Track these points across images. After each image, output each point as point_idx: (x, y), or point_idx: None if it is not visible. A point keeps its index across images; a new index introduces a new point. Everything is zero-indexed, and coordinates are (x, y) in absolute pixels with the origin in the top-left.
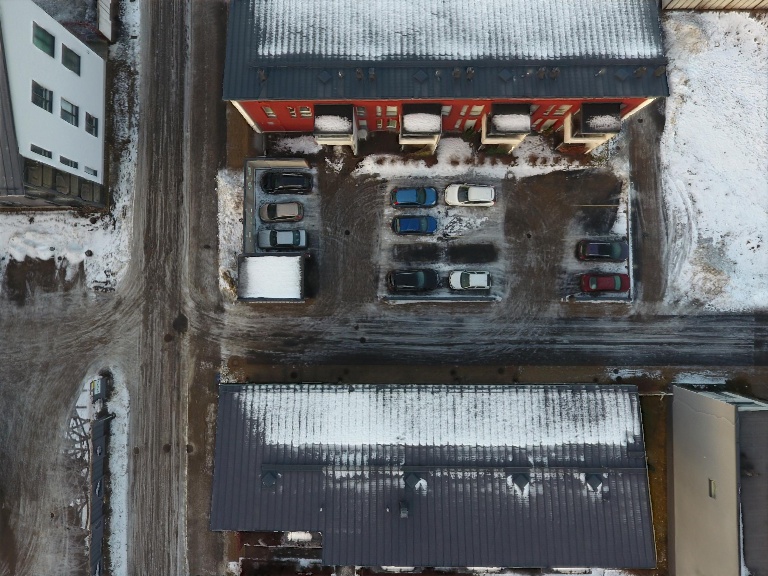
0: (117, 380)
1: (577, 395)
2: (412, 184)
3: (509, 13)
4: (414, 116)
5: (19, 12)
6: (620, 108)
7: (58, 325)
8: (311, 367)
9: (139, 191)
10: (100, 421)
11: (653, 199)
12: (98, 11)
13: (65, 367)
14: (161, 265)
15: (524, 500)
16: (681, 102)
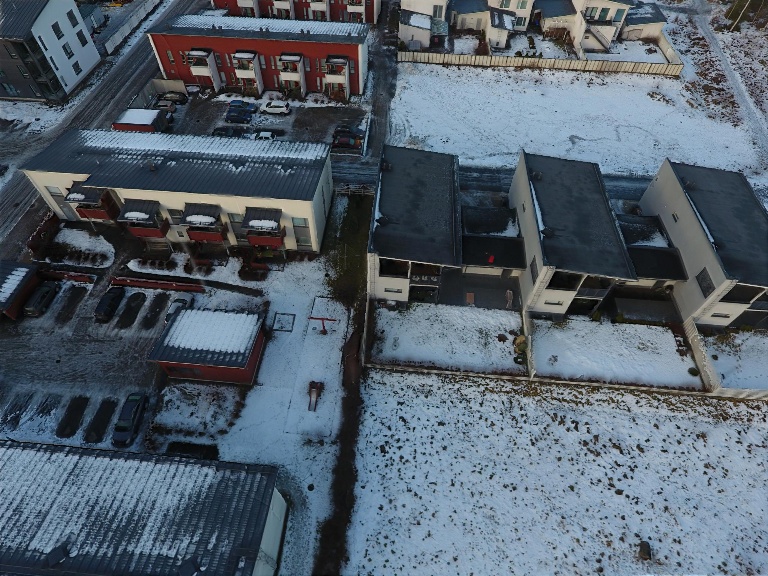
0: (9, 171)
1: (292, 143)
2: None
3: None
4: (241, 53)
5: (67, 1)
6: (354, 66)
7: None
8: None
9: (86, 100)
10: None
11: (384, 119)
12: (109, 40)
13: None
14: (77, 126)
15: (236, 172)
16: (404, 88)
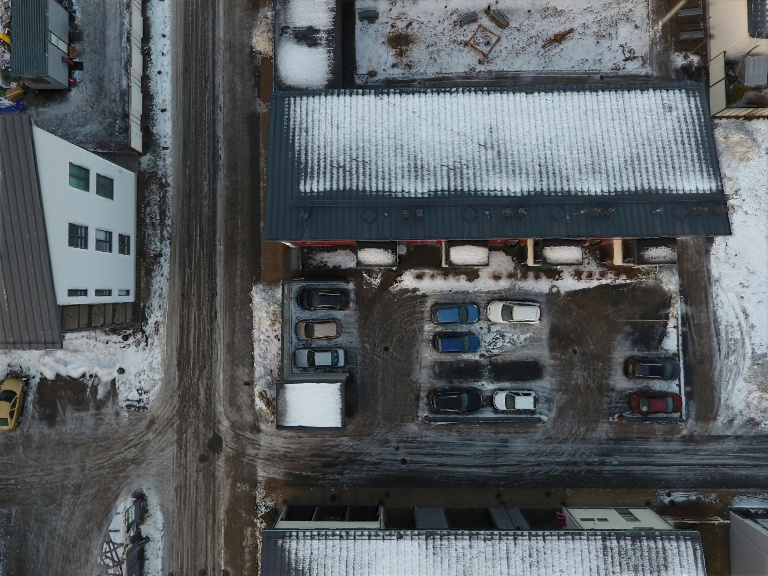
0: (151, 502)
1: (636, 543)
2: (453, 299)
3: (560, 144)
4: (461, 248)
5: (56, 158)
6: None
7: (90, 446)
8: (350, 489)
9: (172, 307)
10: (134, 548)
11: (704, 313)
12: (130, 127)
13: (97, 489)
14: (195, 383)
15: None
16: (732, 212)
